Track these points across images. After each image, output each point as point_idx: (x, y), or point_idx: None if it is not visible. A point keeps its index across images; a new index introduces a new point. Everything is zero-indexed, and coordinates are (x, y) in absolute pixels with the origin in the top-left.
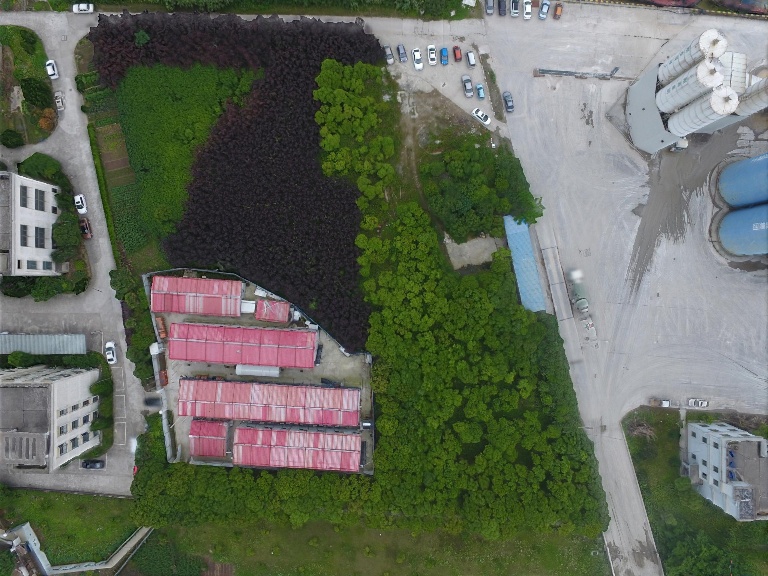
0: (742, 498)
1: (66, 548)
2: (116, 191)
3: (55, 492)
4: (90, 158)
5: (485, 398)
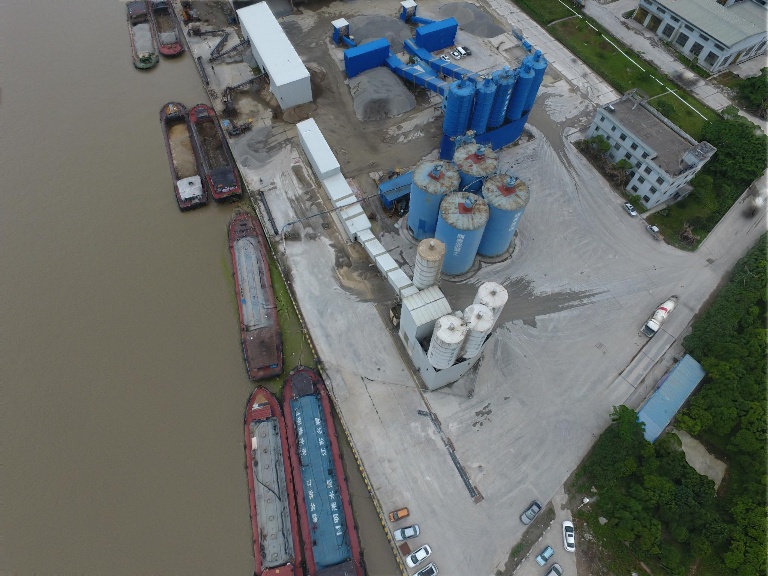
0: (701, 154)
1: None
2: None
3: None
4: None
5: None
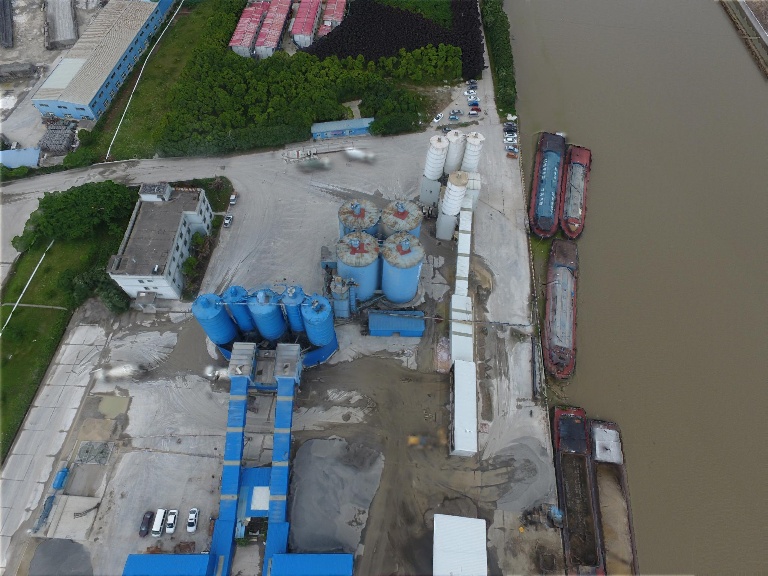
0: (158, 188)
1: None
2: None
3: None
4: None
5: (259, 103)
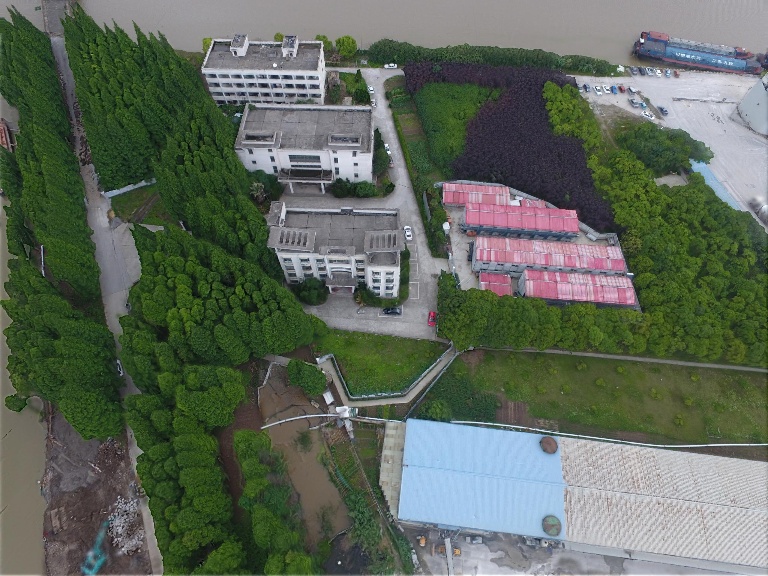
0: None
1: (366, 381)
2: (411, 144)
3: (359, 332)
4: (392, 129)
5: None
